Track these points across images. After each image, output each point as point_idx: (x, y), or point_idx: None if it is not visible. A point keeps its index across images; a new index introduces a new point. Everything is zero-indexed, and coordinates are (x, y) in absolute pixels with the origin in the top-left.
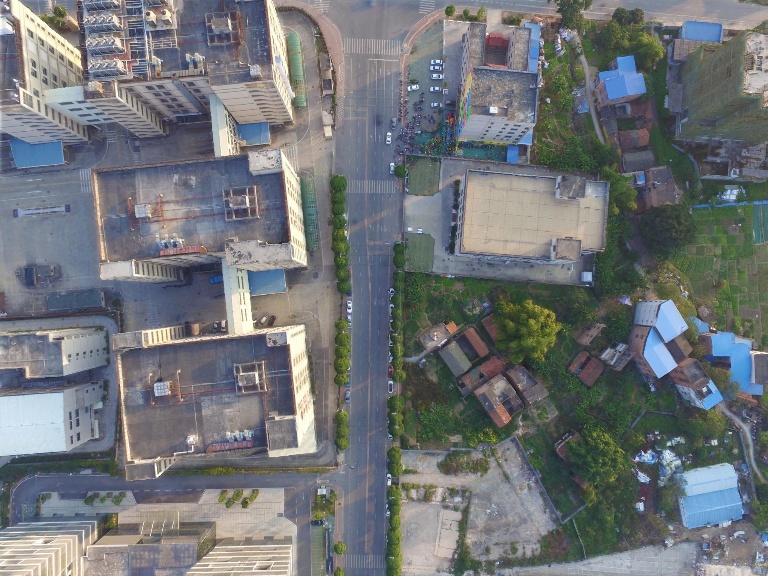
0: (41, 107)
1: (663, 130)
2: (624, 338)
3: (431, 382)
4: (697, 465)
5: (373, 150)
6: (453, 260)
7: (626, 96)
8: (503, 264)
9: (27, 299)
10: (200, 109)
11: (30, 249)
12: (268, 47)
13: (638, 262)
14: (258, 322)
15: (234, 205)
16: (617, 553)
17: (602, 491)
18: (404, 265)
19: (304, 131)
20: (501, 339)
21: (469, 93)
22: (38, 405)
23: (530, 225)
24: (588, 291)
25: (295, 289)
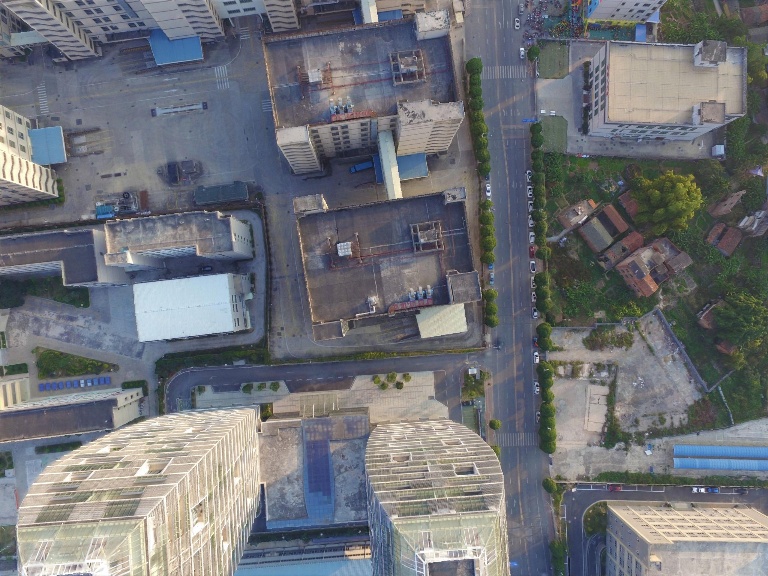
0: None
1: None
2: (760, 206)
3: (573, 259)
4: None
5: (502, 36)
6: (586, 140)
7: None
8: (635, 142)
9: (170, 197)
10: None
11: (170, 147)
12: None
13: (765, 135)
14: None
15: (405, 66)
16: (763, 418)
17: (746, 358)
18: (540, 147)
19: None
20: (643, 211)
21: None
22: (204, 287)
23: (671, 93)
24: None
25: (433, 176)
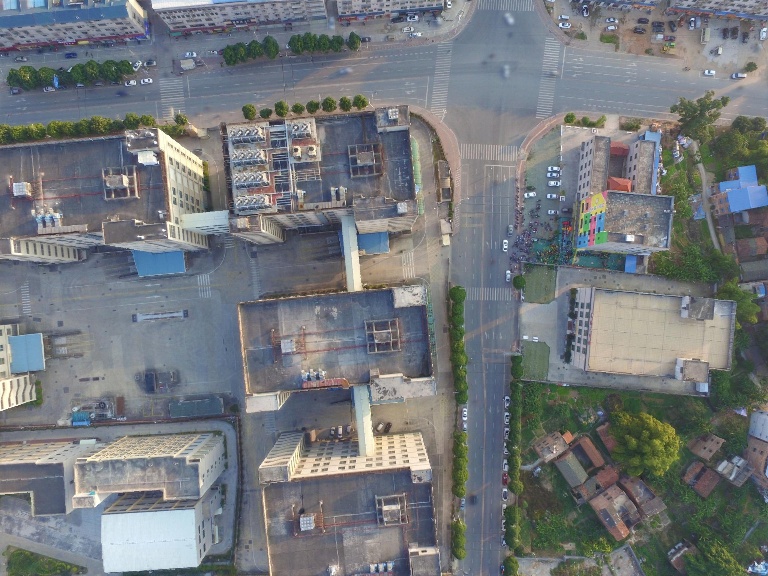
0: (180, 233)
1: None
2: (741, 451)
3: (546, 491)
4: None
5: (489, 257)
6: (568, 368)
7: (748, 208)
8: None
9: (146, 404)
10: (325, 223)
11: (149, 354)
12: (409, 178)
13: (753, 371)
14: (374, 429)
15: (379, 341)
16: None
17: None
18: None
19: (420, 237)
20: (620, 452)
21: (601, 216)
22: (170, 522)
23: (655, 344)
24: (702, 400)
25: None
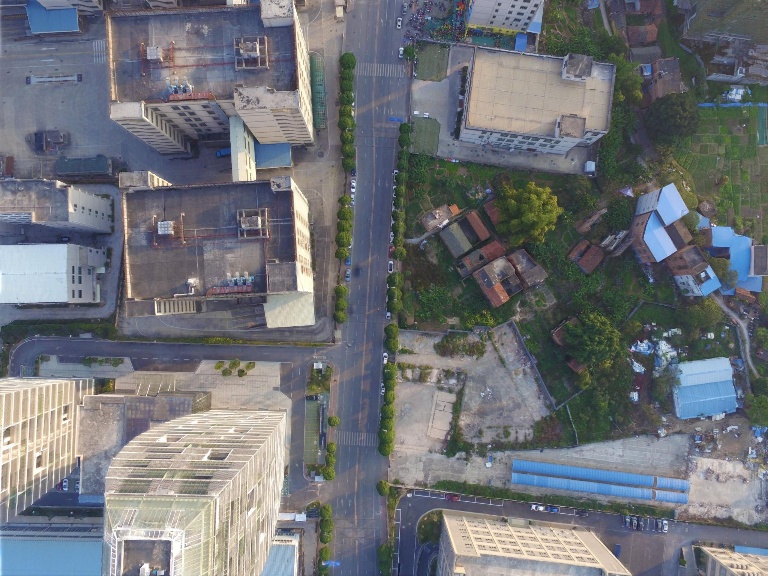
0: None
1: (671, 28)
2: (625, 226)
3: (431, 263)
4: (693, 358)
5: (383, 34)
6: (458, 145)
7: None
8: (507, 152)
9: (36, 165)
10: None
11: (41, 116)
12: None
13: (641, 156)
14: None
15: (244, 51)
16: (609, 441)
17: (597, 378)
18: (409, 147)
19: (316, 13)
20: (502, 220)
21: None
22: (42, 255)
23: (536, 104)
24: (591, 182)
25: (300, 167)
